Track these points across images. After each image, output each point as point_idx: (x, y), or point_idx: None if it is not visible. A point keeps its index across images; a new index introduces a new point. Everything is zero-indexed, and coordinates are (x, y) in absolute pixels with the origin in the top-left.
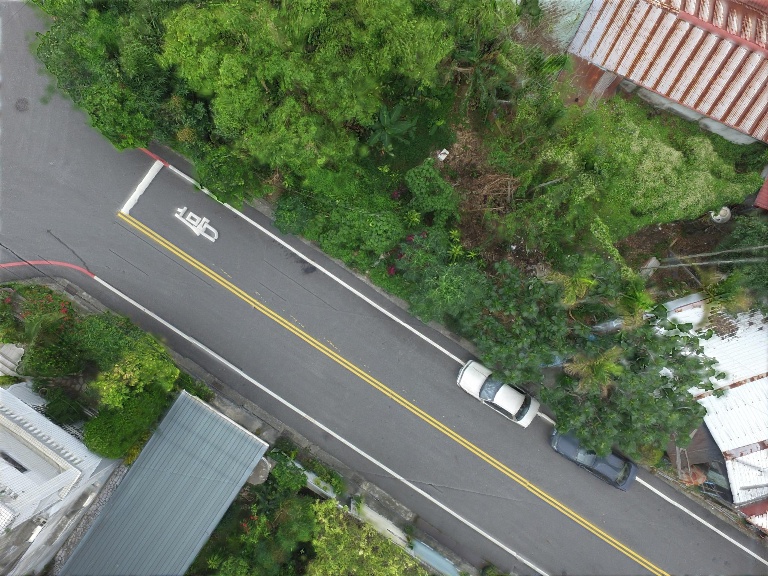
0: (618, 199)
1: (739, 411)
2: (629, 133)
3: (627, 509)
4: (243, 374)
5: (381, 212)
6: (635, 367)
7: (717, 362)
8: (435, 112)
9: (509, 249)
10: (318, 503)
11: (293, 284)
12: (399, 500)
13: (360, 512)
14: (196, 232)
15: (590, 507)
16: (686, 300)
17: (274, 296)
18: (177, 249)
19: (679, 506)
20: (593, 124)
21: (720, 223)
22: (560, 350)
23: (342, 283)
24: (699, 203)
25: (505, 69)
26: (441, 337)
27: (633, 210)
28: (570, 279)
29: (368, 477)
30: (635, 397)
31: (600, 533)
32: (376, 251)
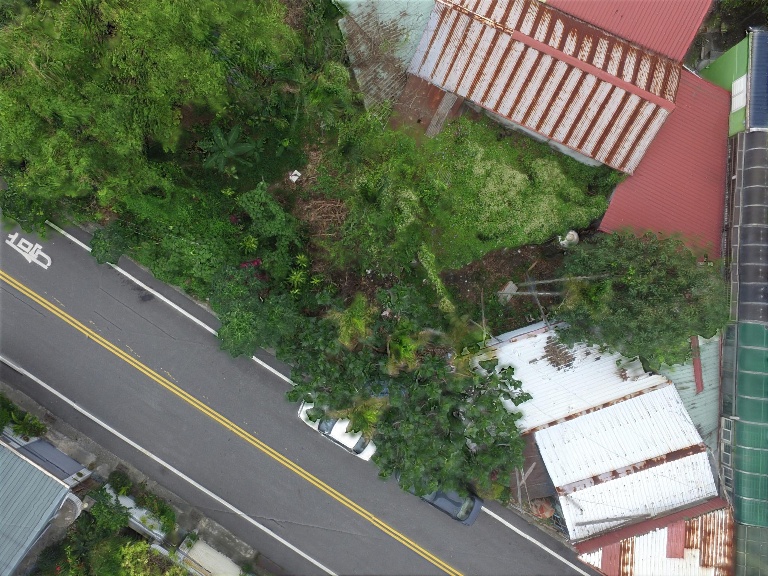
0: (462, 223)
1: (576, 444)
2: (471, 156)
3: (477, 543)
4: (76, 406)
5: (204, 240)
6: (427, 407)
7: (531, 398)
8: (286, 132)
9: (364, 273)
10: (128, 546)
11: (129, 312)
12: (239, 536)
13: (191, 551)
14: (28, 259)
15: (438, 541)
16: (531, 328)
17: (109, 325)
18: (7, 277)
19: (531, 539)
20: (406, 150)
21: (568, 248)
22: (351, 390)
23: (182, 311)
24: (543, 228)
25: (328, 92)
26: (285, 366)
27: (480, 234)
28: (345, 318)
29: (207, 512)
30: (409, 442)
31: (448, 568)
32: (205, 279)
